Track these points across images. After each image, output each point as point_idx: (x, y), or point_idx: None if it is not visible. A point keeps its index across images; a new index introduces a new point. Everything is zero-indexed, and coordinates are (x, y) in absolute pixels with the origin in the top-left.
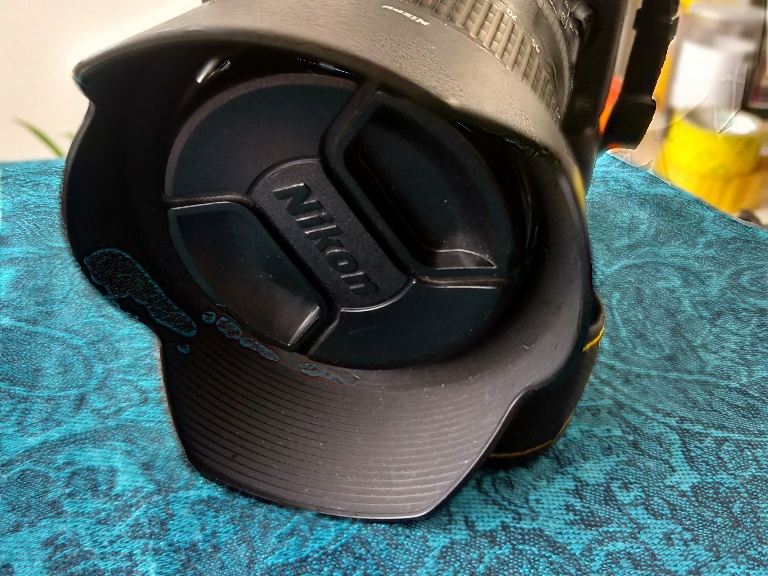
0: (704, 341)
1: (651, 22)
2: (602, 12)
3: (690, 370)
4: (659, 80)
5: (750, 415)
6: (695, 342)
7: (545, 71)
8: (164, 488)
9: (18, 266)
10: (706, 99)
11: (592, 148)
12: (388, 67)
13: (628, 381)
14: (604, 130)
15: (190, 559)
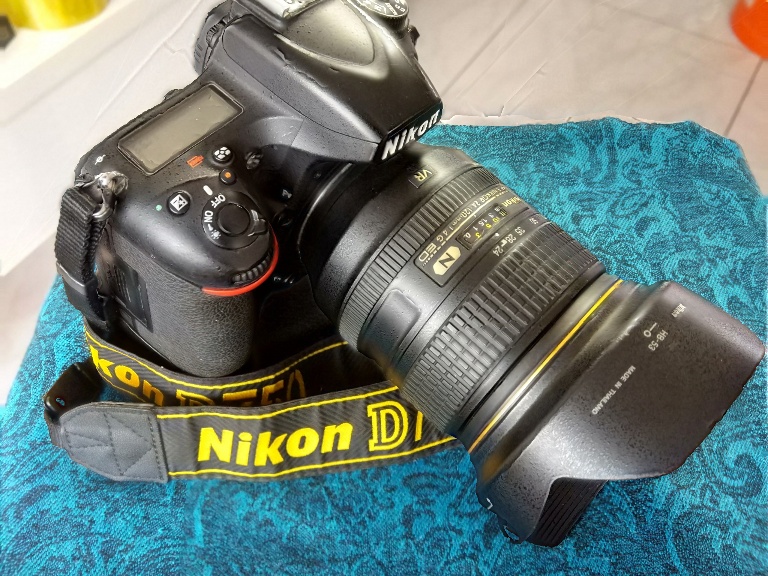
0: None
1: None
2: None
3: None
4: (157, 4)
5: None
6: None
7: None
8: (563, 568)
9: None
10: (202, 1)
11: None
12: (761, 355)
13: None
14: None
15: (623, 569)
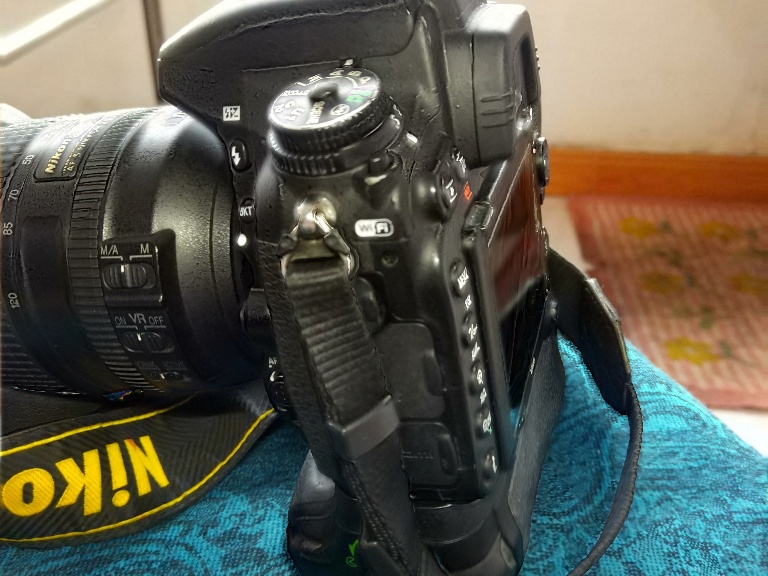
0: None
1: None
2: None
3: None
4: None
5: None
6: None
7: None
8: None
9: None
10: None
11: (353, 520)
12: None
13: None
14: None
15: None
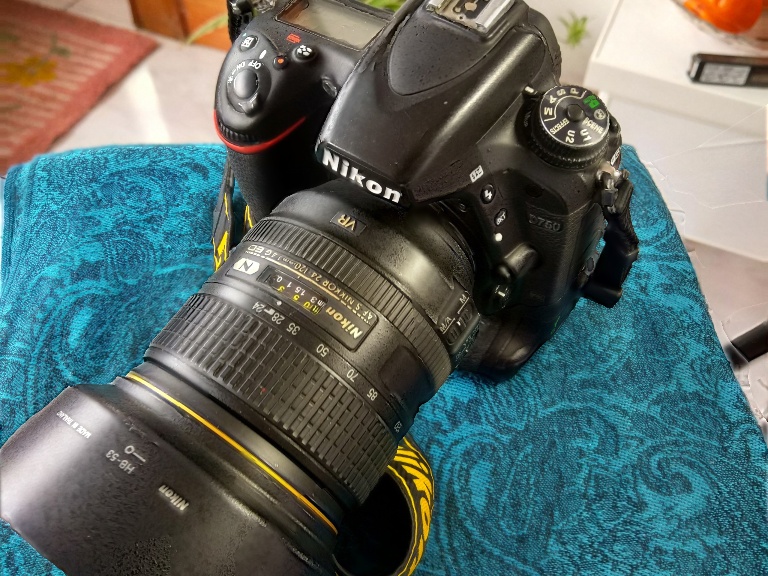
0: (566, 527)
1: (614, 245)
2: (544, 253)
3: (528, 559)
4: None
5: None
6: (557, 526)
7: (377, 413)
8: None
9: (90, 306)
10: None
11: (555, 311)
12: None
13: (471, 556)
14: (582, 287)
15: None
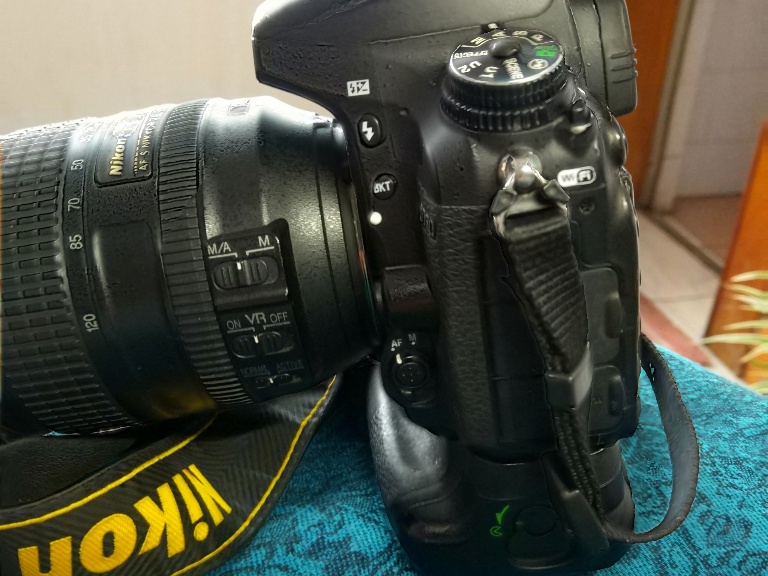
0: None
1: None
2: None
3: None
4: None
5: None
6: None
7: (66, 268)
8: None
9: None
10: None
11: (501, 487)
12: None
13: None
14: None
15: None
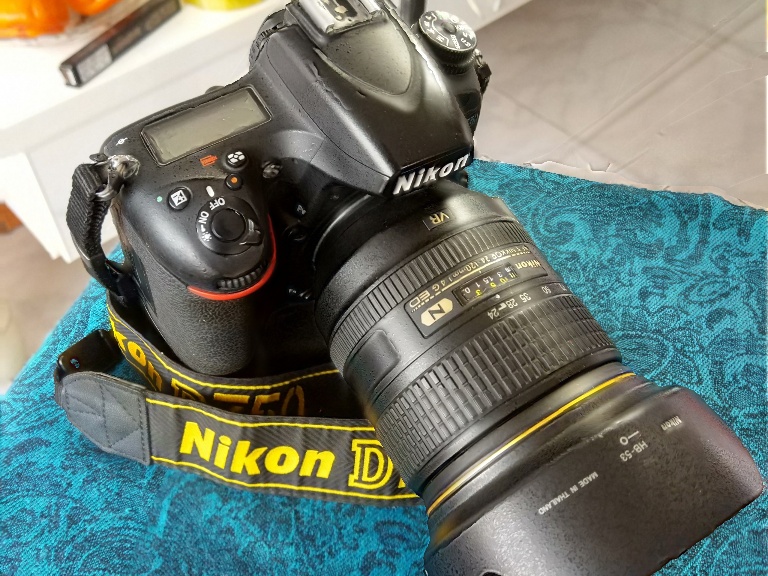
0: None
1: None
2: None
3: None
4: (285, 1)
5: (645, 352)
6: None
7: None
8: None
9: None
10: None
11: None
12: (752, 496)
13: None
14: None
15: None
